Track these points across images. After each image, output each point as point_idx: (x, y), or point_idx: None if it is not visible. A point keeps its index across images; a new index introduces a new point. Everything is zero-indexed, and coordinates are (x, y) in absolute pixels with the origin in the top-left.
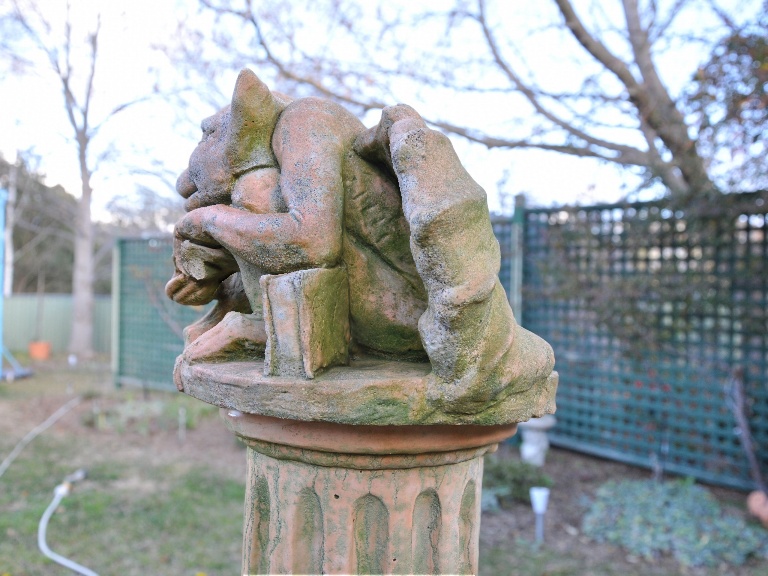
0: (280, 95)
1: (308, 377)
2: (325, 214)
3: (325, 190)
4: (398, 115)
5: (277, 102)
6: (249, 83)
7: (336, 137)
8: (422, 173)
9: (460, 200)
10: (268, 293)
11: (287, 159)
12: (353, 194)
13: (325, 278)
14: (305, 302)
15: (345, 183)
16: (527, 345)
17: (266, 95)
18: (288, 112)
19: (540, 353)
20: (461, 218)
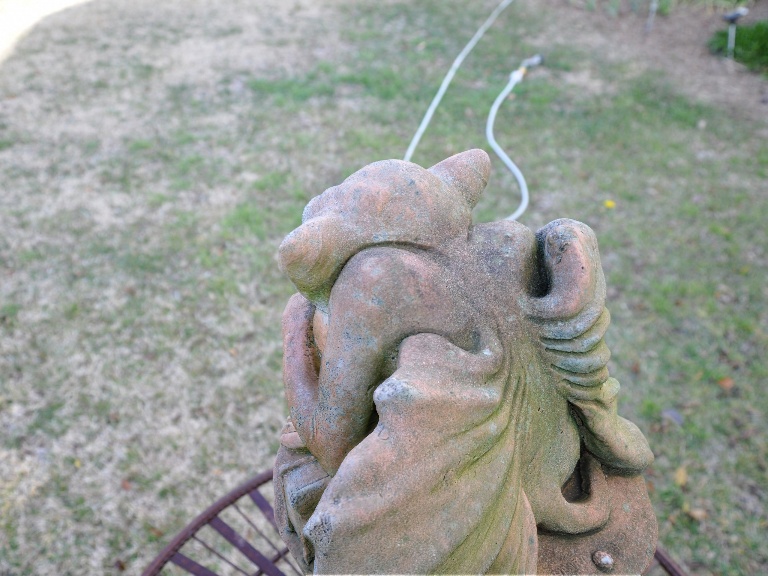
0: (374, 203)
1: None
2: (335, 439)
3: (341, 412)
4: (383, 413)
5: (344, 247)
6: (287, 260)
7: (375, 339)
8: (321, 568)
9: None
10: (283, 483)
11: (324, 348)
12: None
13: None
14: (300, 516)
15: None
16: None
17: (315, 262)
18: (337, 285)
19: None
20: None
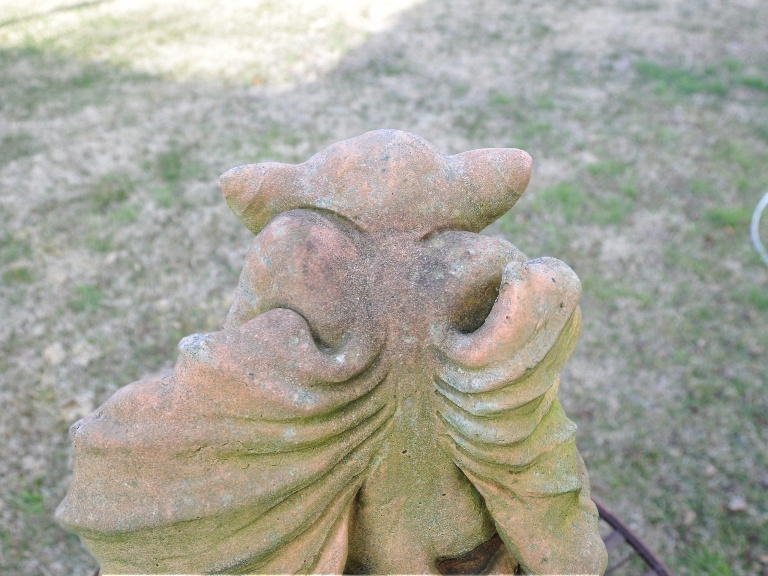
0: (336, 167)
1: None
2: None
3: None
4: None
5: (285, 200)
6: None
7: (257, 298)
8: None
9: (69, 520)
10: None
11: None
12: None
13: None
14: None
15: None
16: None
17: (249, 204)
18: None
19: None
20: (75, 532)
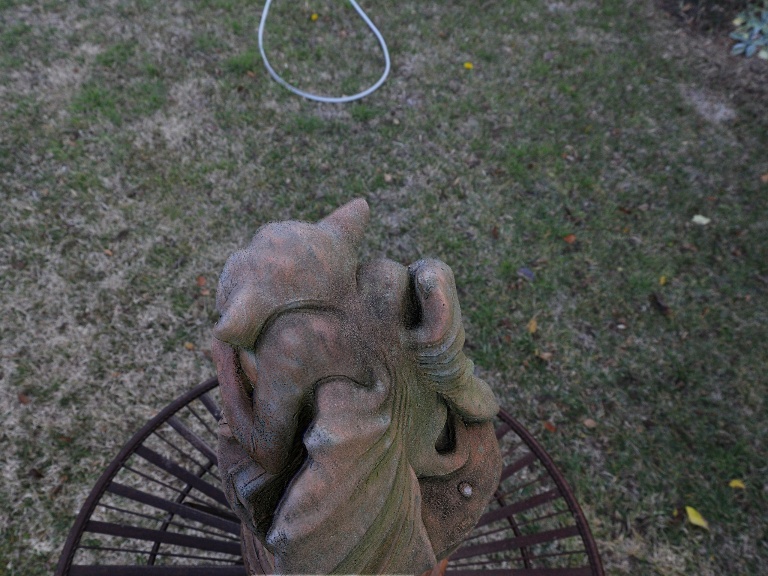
0: (282, 271)
1: (254, 526)
2: (272, 451)
3: (274, 434)
4: (312, 452)
5: (263, 312)
6: (221, 333)
7: (296, 384)
8: (281, 559)
9: None
10: None
11: (256, 387)
12: (312, 415)
13: (271, 480)
14: (249, 502)
15: (307, 404)
16: (403, 568)
17: (242, 330)
18: (262, 344)
19: (413, 572)
20: None
